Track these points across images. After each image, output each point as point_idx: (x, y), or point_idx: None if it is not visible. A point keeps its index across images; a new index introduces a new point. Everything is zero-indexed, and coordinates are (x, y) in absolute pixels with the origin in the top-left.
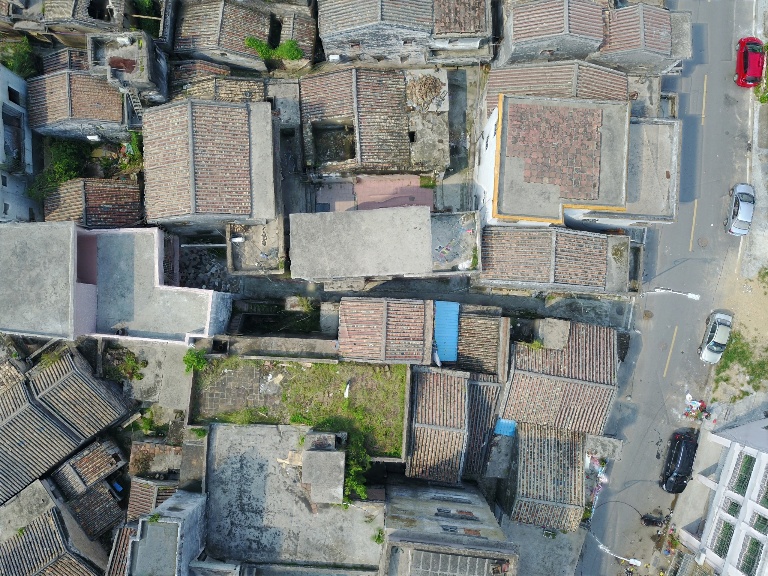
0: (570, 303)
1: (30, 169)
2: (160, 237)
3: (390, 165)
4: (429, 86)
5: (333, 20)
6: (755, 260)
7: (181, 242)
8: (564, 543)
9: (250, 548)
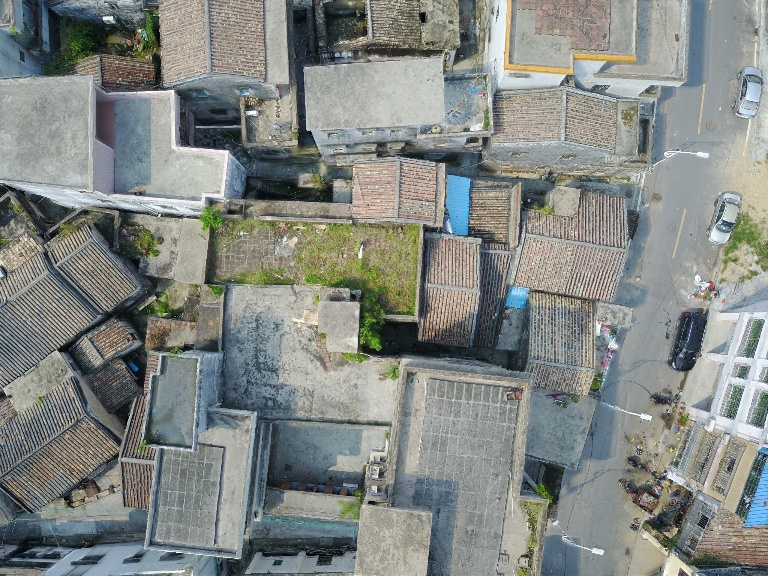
0: (579, 186)
1: (47, 47)
2: (176, 102)
3: (401, 43)
4: None
5: None
6: (763, 143)
7: (195, 123)
8: (575, 412)
9: (266, 405)
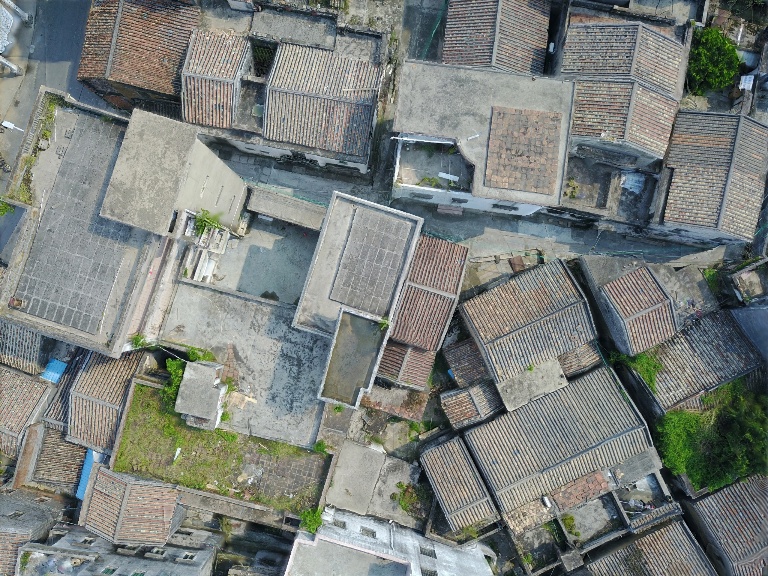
0: None
1: None
2: None
3: None
4: None
5: None
6: None
7: None
8: None
9: None
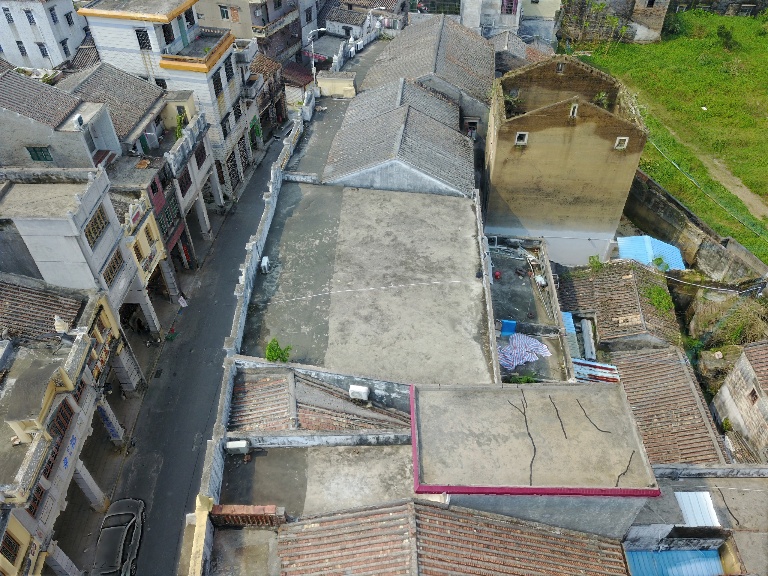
0: None
1: None
2: None
3: None
4: None
5: None
6: None
7: None
8: None
9: None
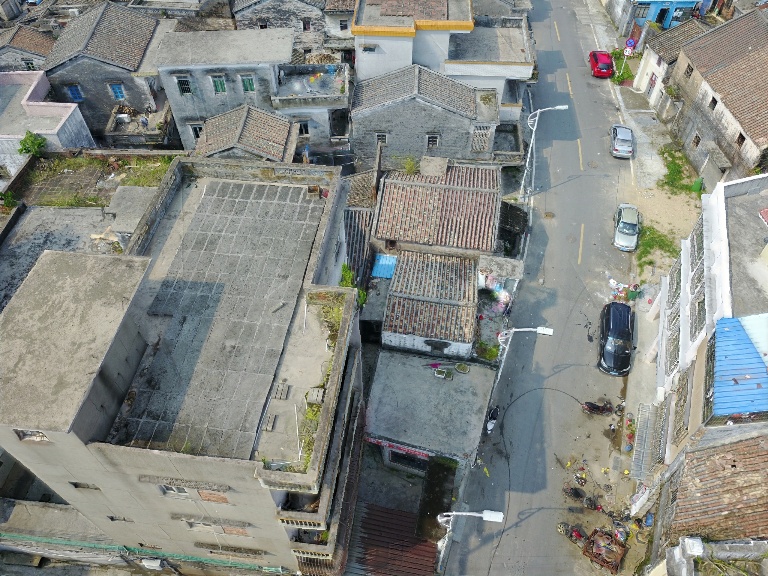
0: None
1: None
2: (45, 83)
3: None
4: (324, 55)
5: (245, 2)
6: (649, 175)
7: None
8: (465, 386)
9: None
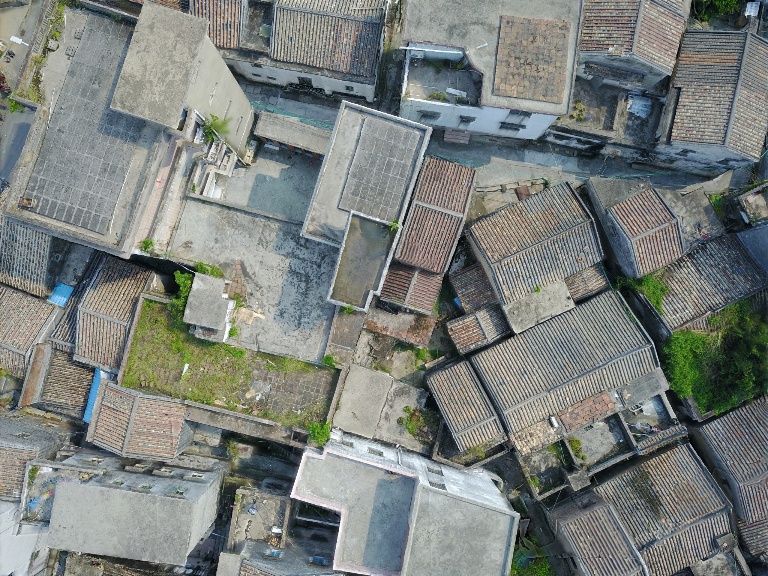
0: None
1: None
2: None
3: (121, 570)
4: None
5: None
6: None
7: None
8: None
9: (307, 240)
